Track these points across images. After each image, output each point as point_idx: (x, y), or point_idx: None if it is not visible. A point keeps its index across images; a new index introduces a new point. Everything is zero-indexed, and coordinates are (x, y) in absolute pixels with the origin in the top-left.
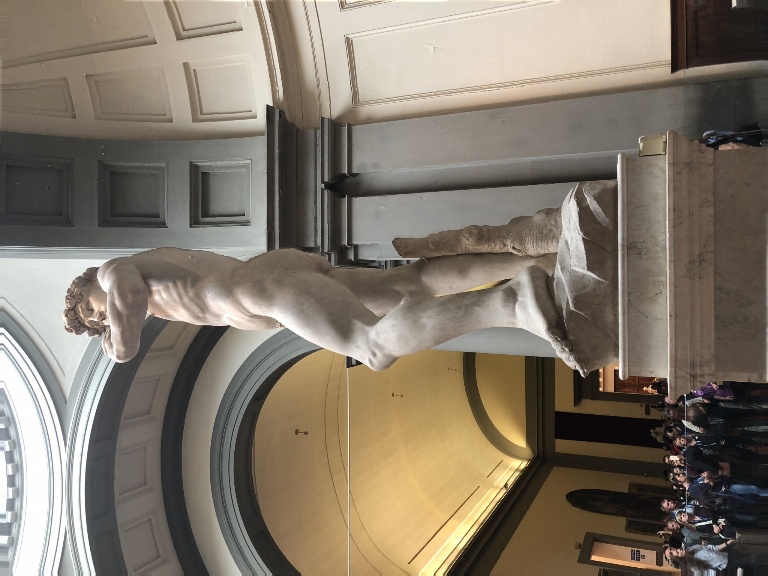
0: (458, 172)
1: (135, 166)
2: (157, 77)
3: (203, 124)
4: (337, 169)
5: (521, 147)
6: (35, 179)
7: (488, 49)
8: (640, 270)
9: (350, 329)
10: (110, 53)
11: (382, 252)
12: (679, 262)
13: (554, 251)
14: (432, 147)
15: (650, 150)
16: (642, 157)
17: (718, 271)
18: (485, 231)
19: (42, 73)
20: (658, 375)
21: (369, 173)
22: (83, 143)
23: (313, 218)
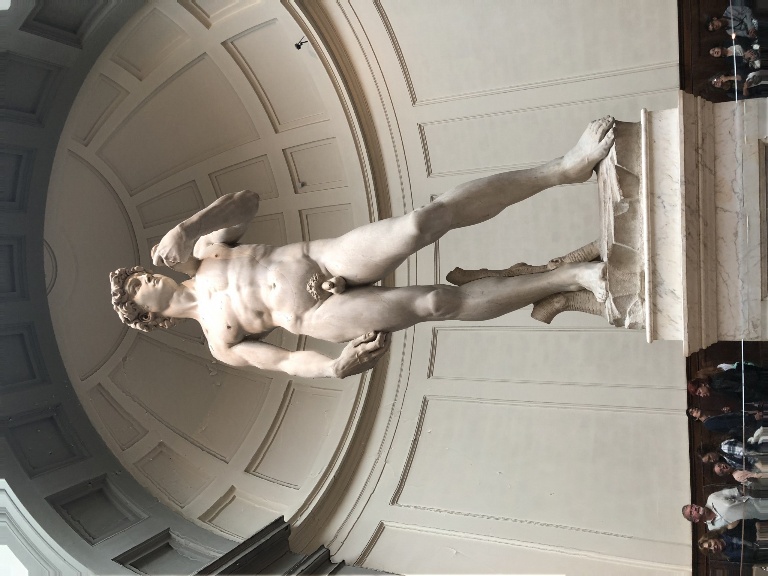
0: None
1: (122, 502)
2: (203, 483)
3: (204, 524)
4: None
5: None
6: (51, 443)
7: (508, 570)
8: None
9: None
10: (192, 445)
11: None
12: None
13: (587, 249)
14: None
15: None
16: None
17: None
18: None
19: None
20: None
21: None
22: (110, 460)
23: None
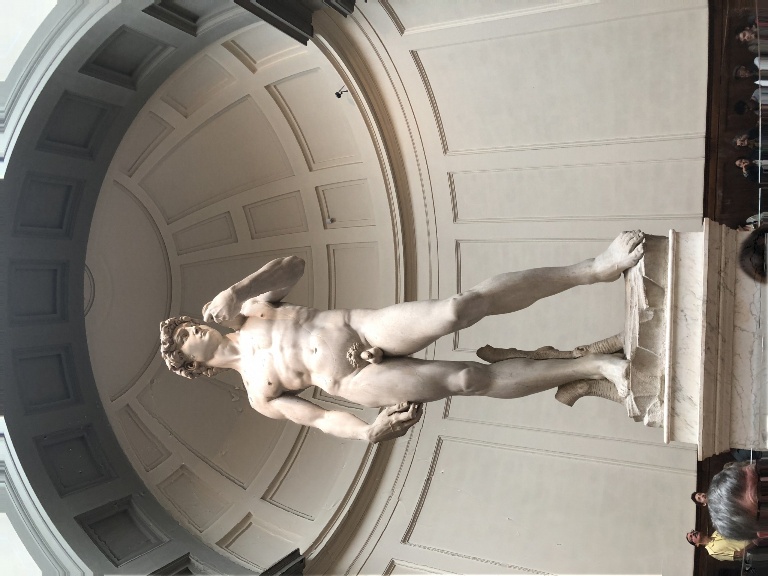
0: None
1: (145, 524)
2: (221, 508)
3: (222, 550)
4: None
5: None
6: (81, 462)
7: None
8: None
9: None
10: (212, 470)
11: None
12: None
13: (612, 341)
14: None
15: None
16: None
17: None
18: None
19: None
20: None
21: None
22: (135, 481)
23: None
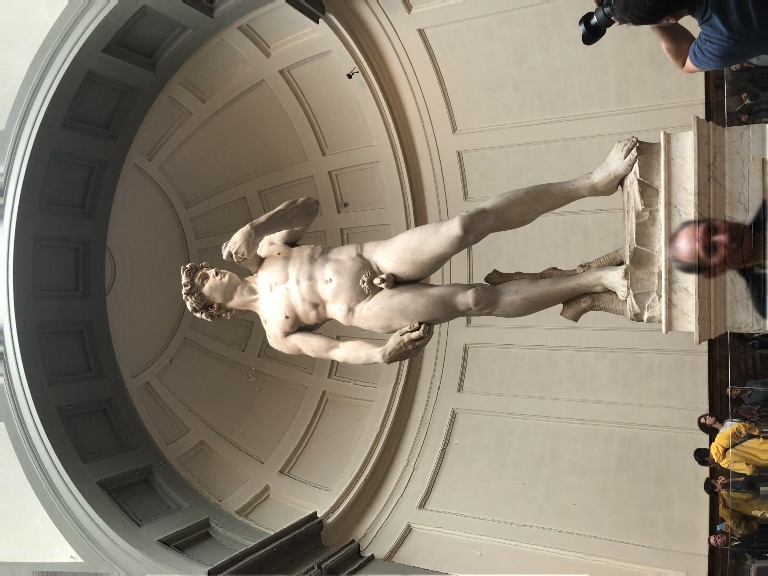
0: None
1: (166, 491)
2: (239, 481)
3: (241, 517)
4: (339, 569)
5: None
6: (103, 432)
7: (529, 572)
8: None
9: None
10: (230, 445)
11: None
12: None
13: (612, 255)
14: None
15: None
16: None
17: None
18: None
19: (181, 418)
20: None
21: None
22: (156, 452)
23: None
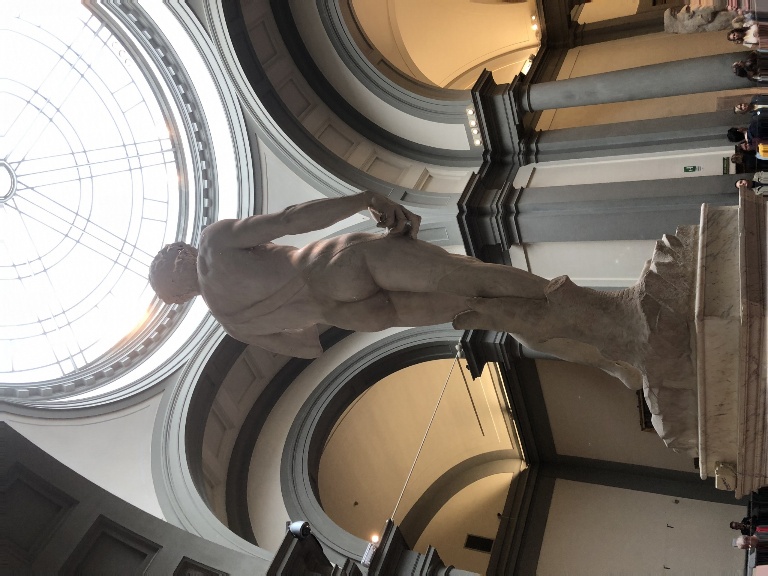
0: None
1: None
2: None
3: None
4: None
5: None
6: None
7: None
8: None
9: None
10: None
11: None
12: None
13: None
14: None
15: None
16: None
17: None
18: None
19: None
20: None
21: None
22: None
23: None
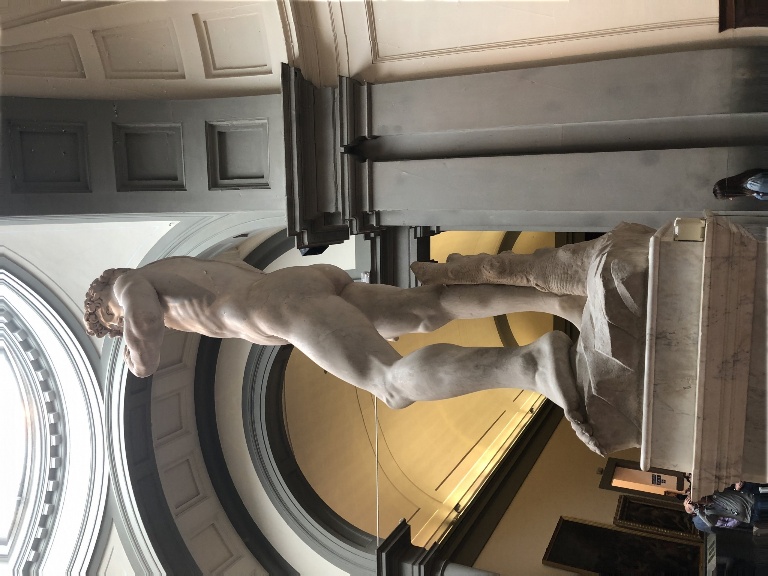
0: (484, 136)
1: (150, 127)
2: (166, 30)
3: (217, 80)
4: (357, 132)
5: (551, 112)
6: (50, 144)
7: None
8: (668, 362)
9: (367, 366)
10: (116, 6)
11: (404, 218)
12: (711, 363)
13: (579, 294)
14: (456, 110)
15: (686, 235)
16: (677, 242)
17: (753, 372)
18: (507, 264)
19: (47, 31)
20: (682, 470)
21: (390, 135)
22: (95, 105)
23: (333, 183)
